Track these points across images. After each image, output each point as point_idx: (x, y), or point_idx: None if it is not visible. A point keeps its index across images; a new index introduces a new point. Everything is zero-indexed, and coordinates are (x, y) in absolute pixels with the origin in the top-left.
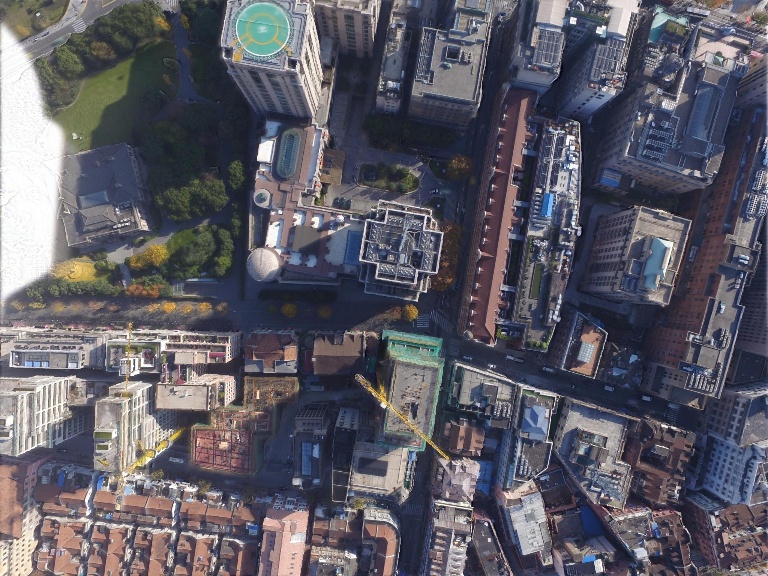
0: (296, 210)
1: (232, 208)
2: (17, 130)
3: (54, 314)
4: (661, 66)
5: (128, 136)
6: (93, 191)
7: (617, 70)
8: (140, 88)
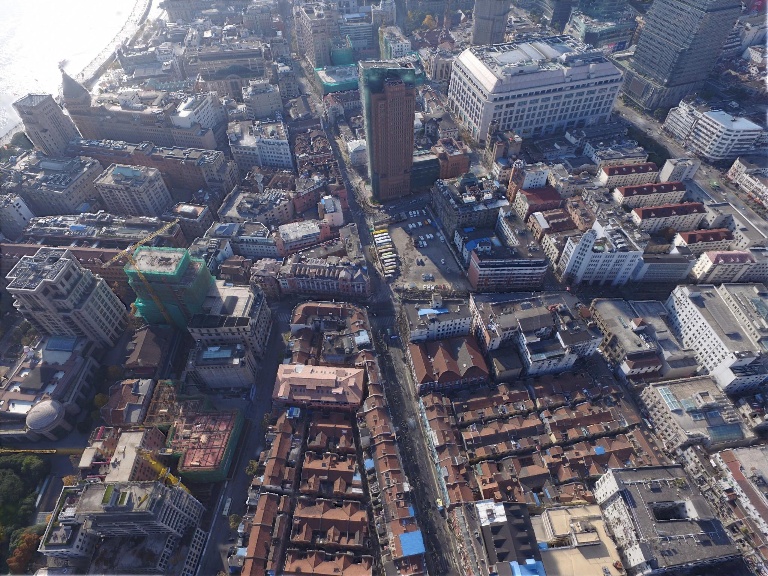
0: (7, 390)
1: None
2: None
3: None
4: (16, 182)
5: None
6: None
7: (3, 196)
8: None
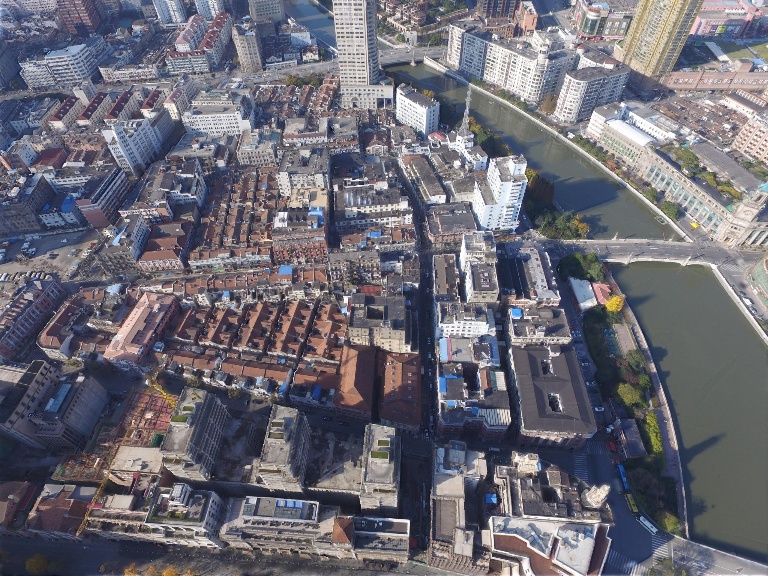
0: None
1: None
2: None
3: (319, 575)
4: None
5: None
6: None
7: None
8: None
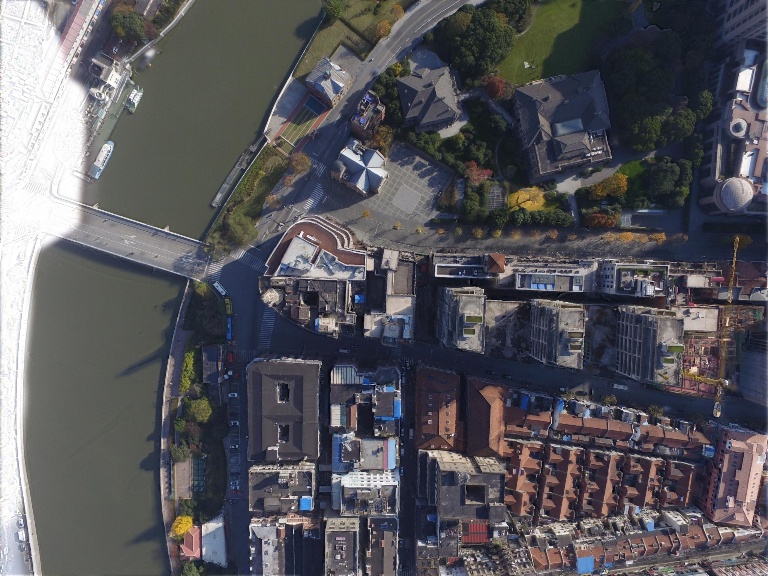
0: None
1: (695, 138)
2: (497, 55)
3: (501, 244)
4: None
5: (579, 65)
6: (568, 118)
7: None
8: (592, 16)
